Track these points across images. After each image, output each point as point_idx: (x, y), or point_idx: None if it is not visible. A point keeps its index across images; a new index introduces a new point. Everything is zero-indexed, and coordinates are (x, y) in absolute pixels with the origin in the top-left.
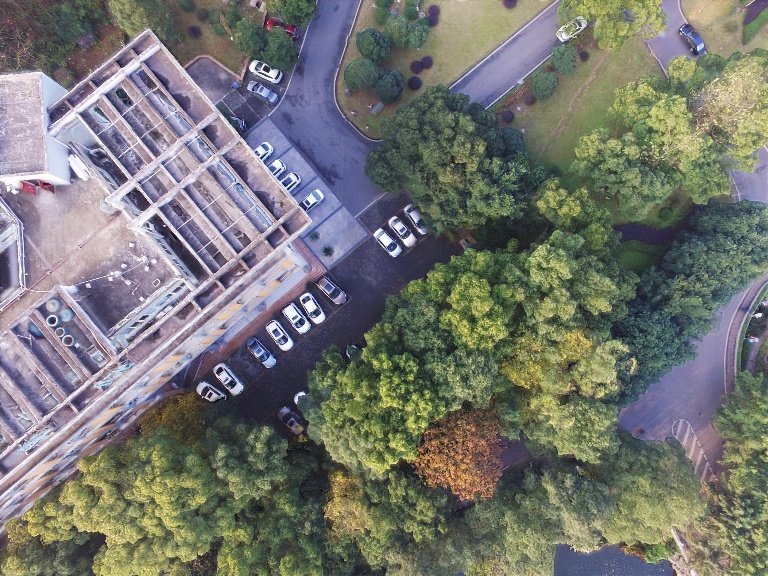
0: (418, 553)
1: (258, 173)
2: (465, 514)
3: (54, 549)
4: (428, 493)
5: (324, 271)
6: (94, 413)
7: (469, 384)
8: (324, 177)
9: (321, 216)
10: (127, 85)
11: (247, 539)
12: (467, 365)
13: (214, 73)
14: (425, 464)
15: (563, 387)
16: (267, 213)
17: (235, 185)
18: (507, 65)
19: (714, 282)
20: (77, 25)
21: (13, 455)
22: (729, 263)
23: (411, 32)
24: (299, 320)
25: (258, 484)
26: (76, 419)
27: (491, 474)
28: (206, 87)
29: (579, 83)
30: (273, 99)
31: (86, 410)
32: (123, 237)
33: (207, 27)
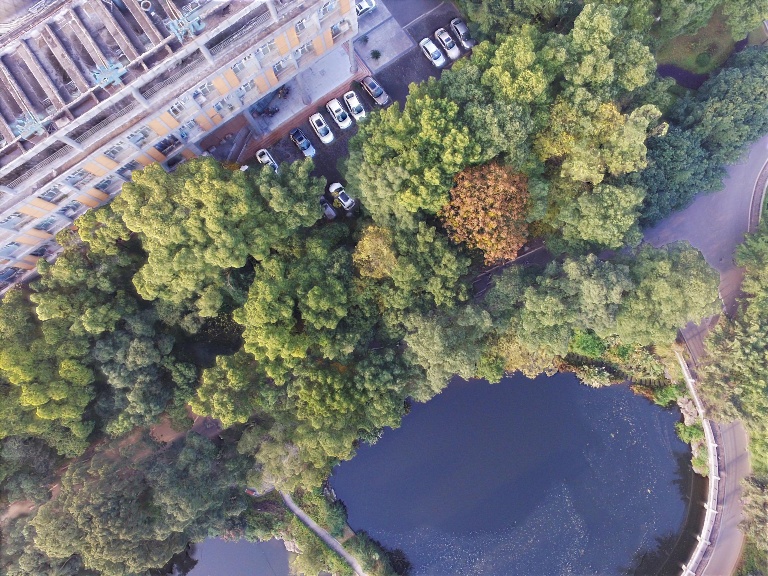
0: (438, 317)
1: None
2: (485, 296)
3: (98, 264)
4: (454, 252)
5: (369, 74)
6: (155, 108)
7: (505, 134)
8: None
9: (371, 24)
10: None
11: (279, 273)
12: (505, 112)
13: None
14: (455, 212)
15: (594, 155)
16: None
17: None
18: None
19: (747, 106)
20: None
21: (85, 105)
22: (763, 90)
23: None
24: (341, 114)
25: (296, 208)
26: (146, 76)
27: (516, 238)
28: None
29: None
30: None
31: (156, 68)
32: None
33: None
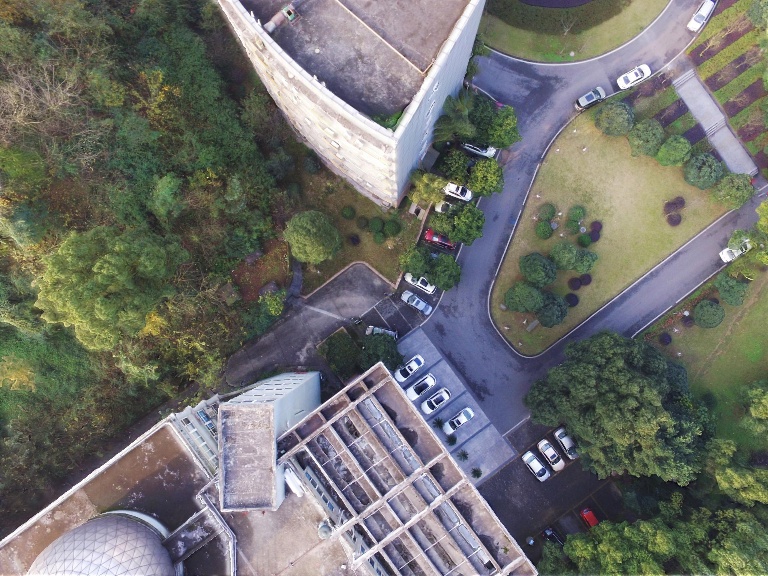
0: None
1: (483, 516)
2: None
3: None
4: None
5: None
6: None
7: None
8: (473, 392)
9: (468, 432)
10: (354, 415)
11: None
12: None
13: (368, 279)
14: None
15: None
16: (492, 561)
17: (459, 526)
18: (666, 283)
19: None
20: (246, 244)
21: None
22: None
23: (579, 261)
24: None
25: None
26: None
27: None
28: (359, 293)
29: (739, 306)
30: (428, 312)
31: None
32: (335, 557)
33: (365, 234)
